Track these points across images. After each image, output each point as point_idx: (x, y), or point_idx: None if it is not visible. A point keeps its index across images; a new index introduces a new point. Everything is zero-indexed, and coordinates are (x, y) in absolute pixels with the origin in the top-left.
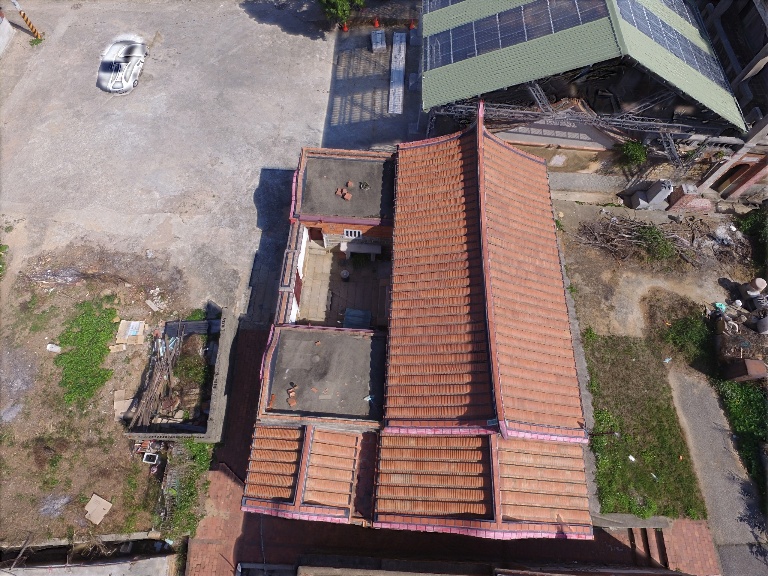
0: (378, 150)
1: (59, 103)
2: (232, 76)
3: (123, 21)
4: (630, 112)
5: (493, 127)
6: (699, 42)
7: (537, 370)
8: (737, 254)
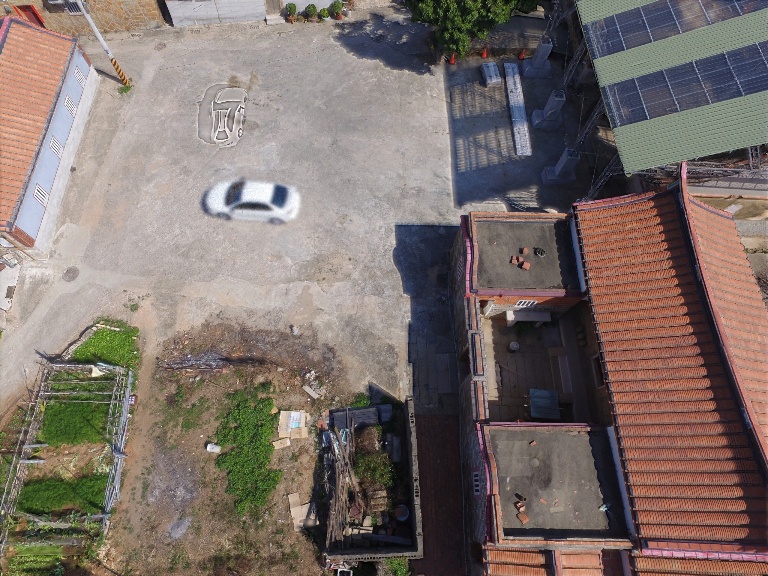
0: (514, 198)
1: (163, 159)
2: (342, 120)
3: (213, 62)
4: None
5: None
6: None
7: None
8: None
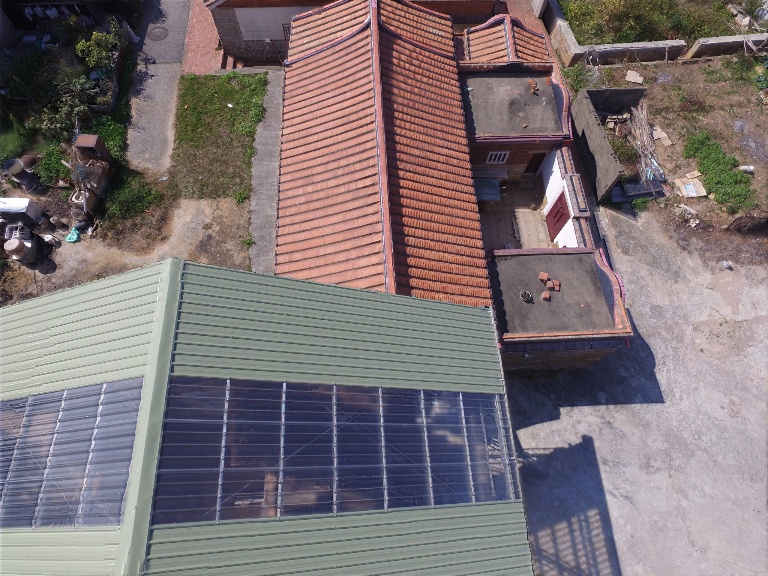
0: None
1: None
2: None
3: None
4: None
5: None
6: None
7: None
8: None
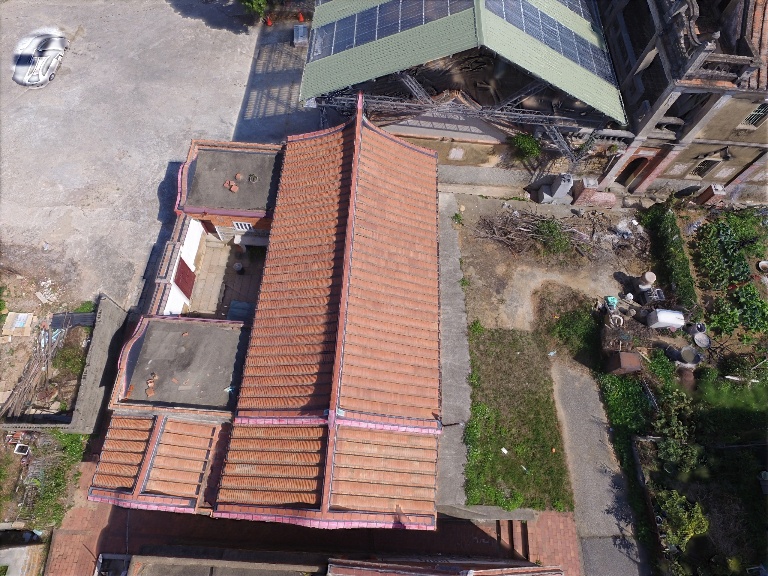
0: None
1: None
2: (150, 70)
3: (47, 15)
4: (508, 104)
5: (382, 120)
6: (588, 35)
7: (394, 361)
8: (636, 248)
